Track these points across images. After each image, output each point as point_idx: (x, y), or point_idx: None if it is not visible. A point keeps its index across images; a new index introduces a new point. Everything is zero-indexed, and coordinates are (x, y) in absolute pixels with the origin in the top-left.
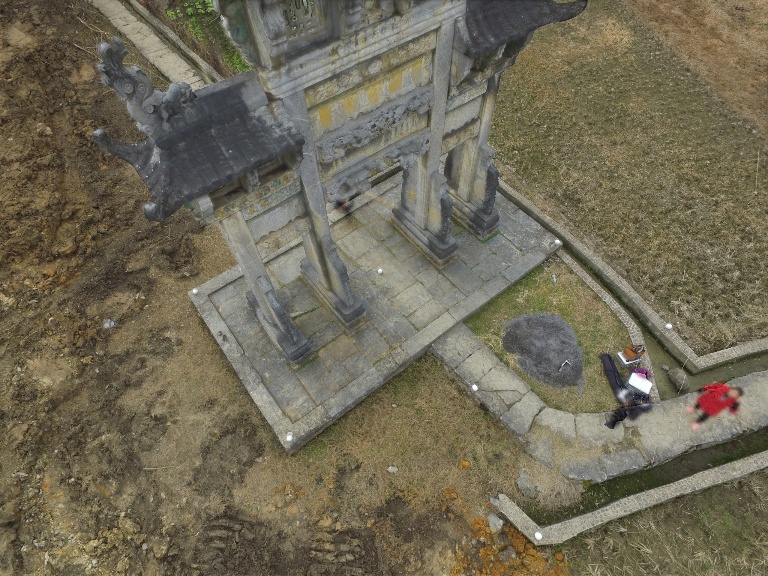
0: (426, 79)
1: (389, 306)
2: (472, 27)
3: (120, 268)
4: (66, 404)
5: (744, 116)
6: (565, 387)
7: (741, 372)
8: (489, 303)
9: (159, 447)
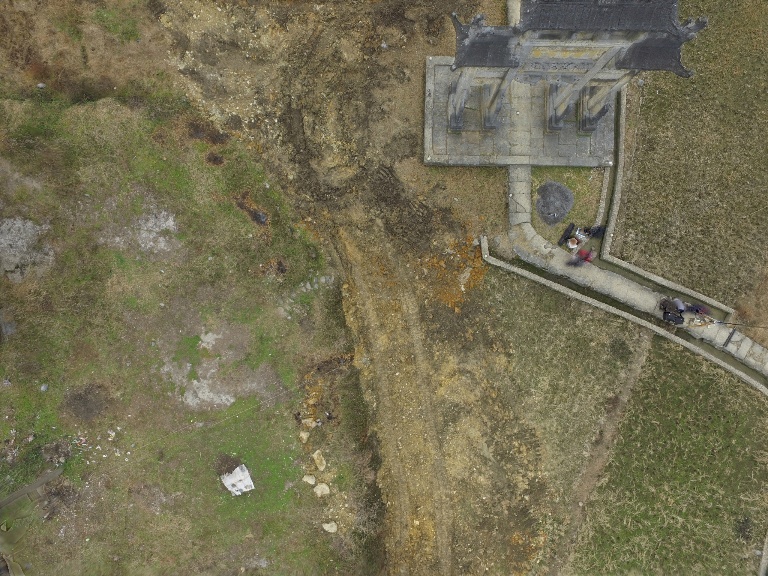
0: (595, 58)
1: (508, 134)
2: (628, 54)
3: (402, 12)
4: (349, 74)
5: None
6: (545, 223)
7: (620, 274)
8: (551, 166)
9: (378, 124)
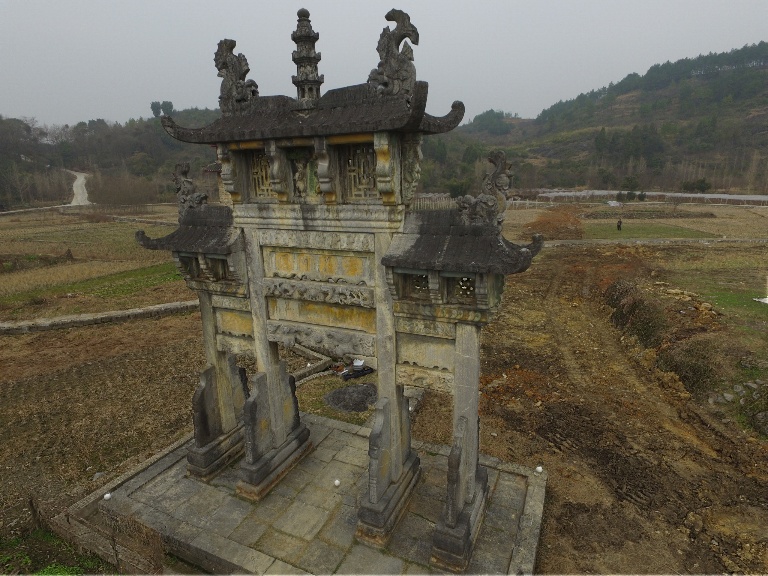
0: None
1: None
2: None
3: None
4: None
5: (67, 367)
6: None
7: None
8: None
9: None
